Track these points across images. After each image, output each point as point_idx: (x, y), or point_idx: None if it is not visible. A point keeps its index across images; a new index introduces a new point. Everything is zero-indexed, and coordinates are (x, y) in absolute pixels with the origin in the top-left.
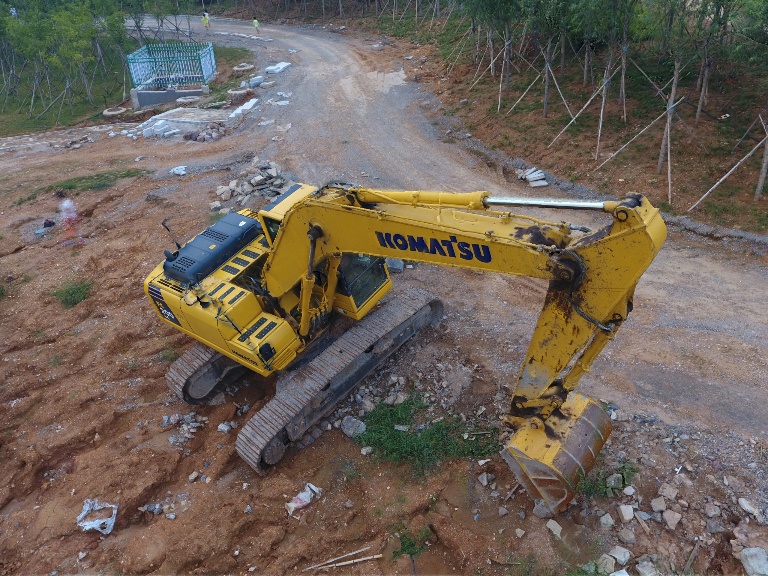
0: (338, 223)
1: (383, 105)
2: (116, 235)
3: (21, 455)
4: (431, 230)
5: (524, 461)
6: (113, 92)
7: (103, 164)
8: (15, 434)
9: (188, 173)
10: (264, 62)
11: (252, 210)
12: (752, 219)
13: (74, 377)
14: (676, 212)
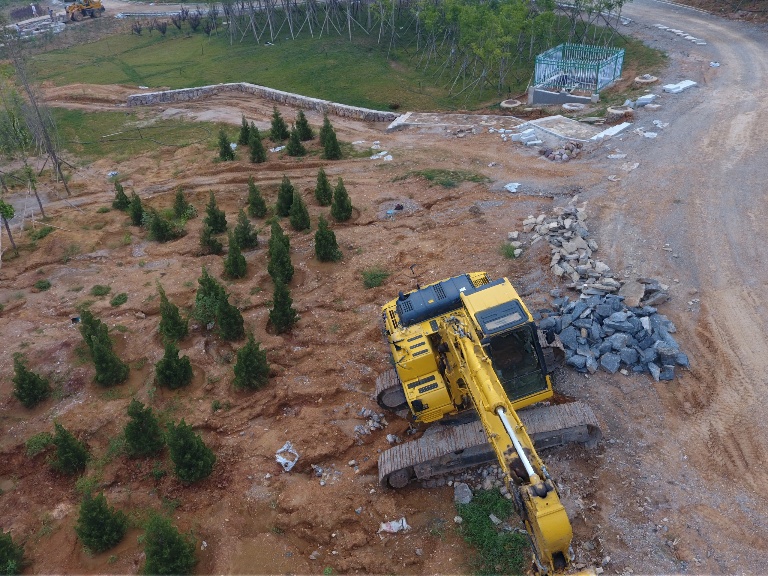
0: None
1: (759, 162)
2: (429, 237)
3: (276, 390)
4: None
5: None
6: (523, 81)
7: (466, 161)
8: (285, 372)
9: (518, 192)
10: (671, 75)
11: (486, 275)
12: None
13: (337, 346)
14: None
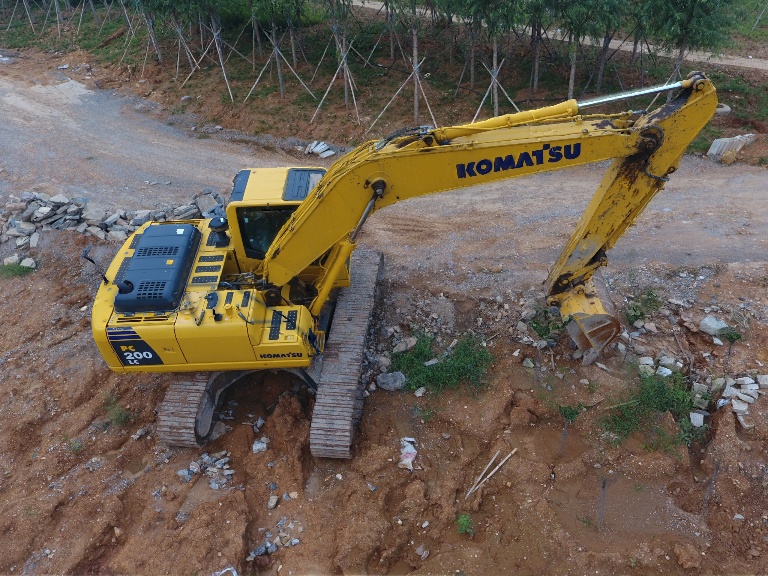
0: (410, 169)
1: (92, 116)
2: None
3: None
4: (525, 145)
5: (585, 320)
6: None
7: None
8: None
9: None
10: None
11: None
12: None
13: None
14: None
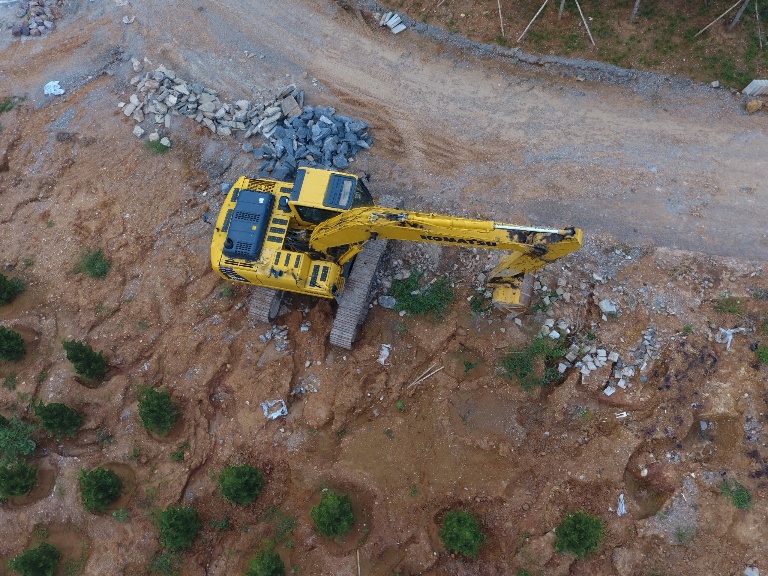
0: None
1: None
2: (71, 192)
3: (196, 398)
4: (461, 237)
5: None
6: None
7: None
8: (170, 386)
9: (66, 90)
10: None
11: (249, 178)
12: (561, 43)
13: (166, 332)
14: (510, 44)
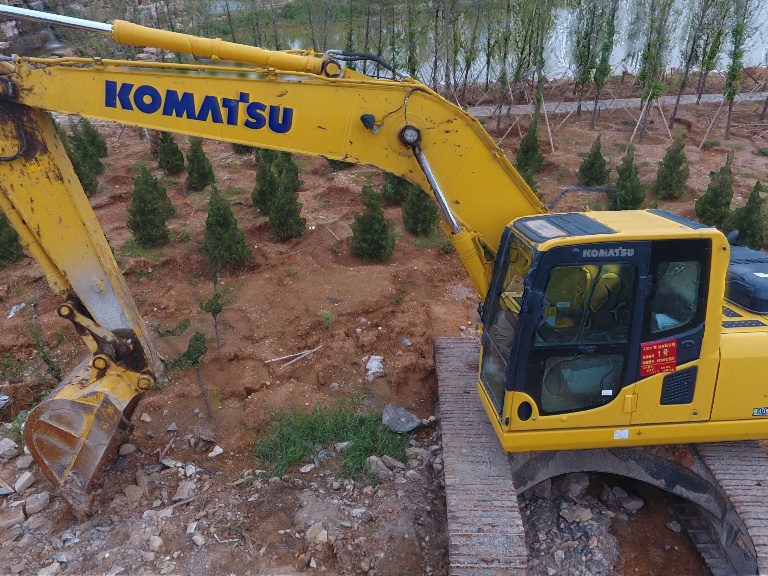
0: None
1: None
2: None
3: None
4: None
5: None
6: None
7: None
8: None
9: None
10: None
11: None
12: None
13: None
14: None
